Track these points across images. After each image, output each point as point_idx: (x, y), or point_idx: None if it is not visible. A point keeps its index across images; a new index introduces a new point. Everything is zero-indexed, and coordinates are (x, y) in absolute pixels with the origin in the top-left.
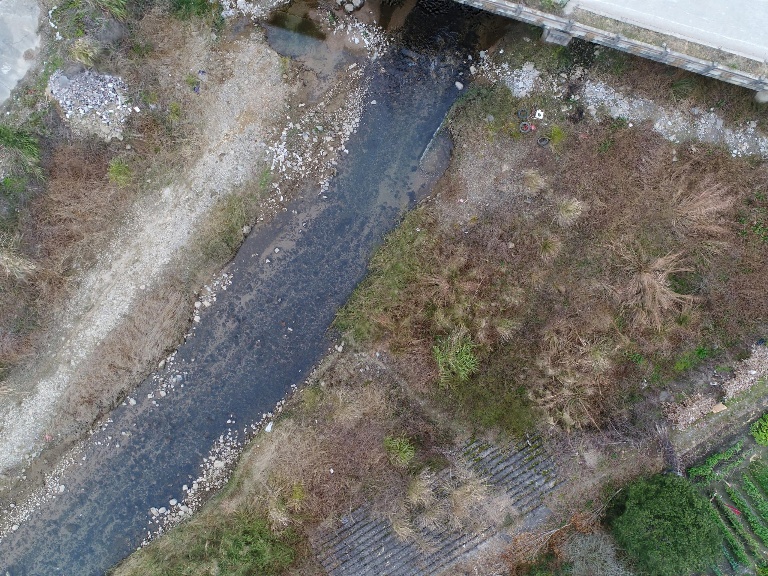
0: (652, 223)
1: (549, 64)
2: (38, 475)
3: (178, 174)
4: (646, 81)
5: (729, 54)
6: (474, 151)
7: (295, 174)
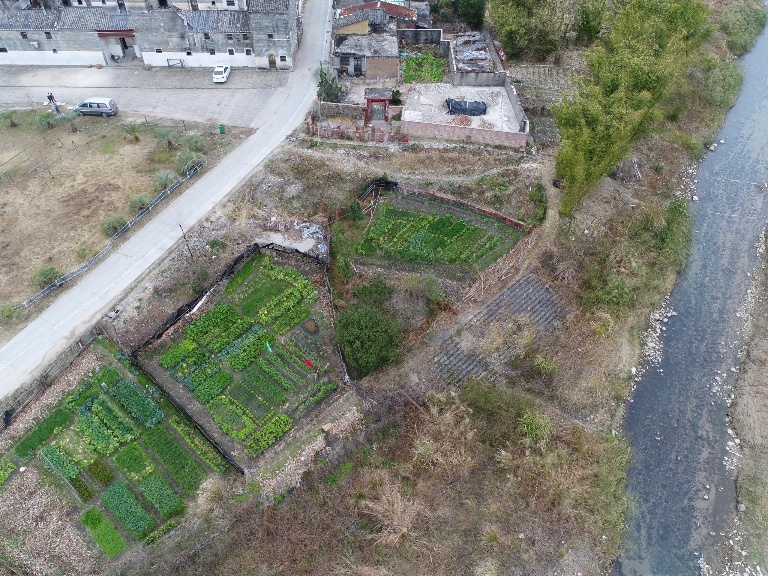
0: (411, 575)
1: None
2: (759, 319)
3: None
4: None
5: None
6: None
7: (735, 568)
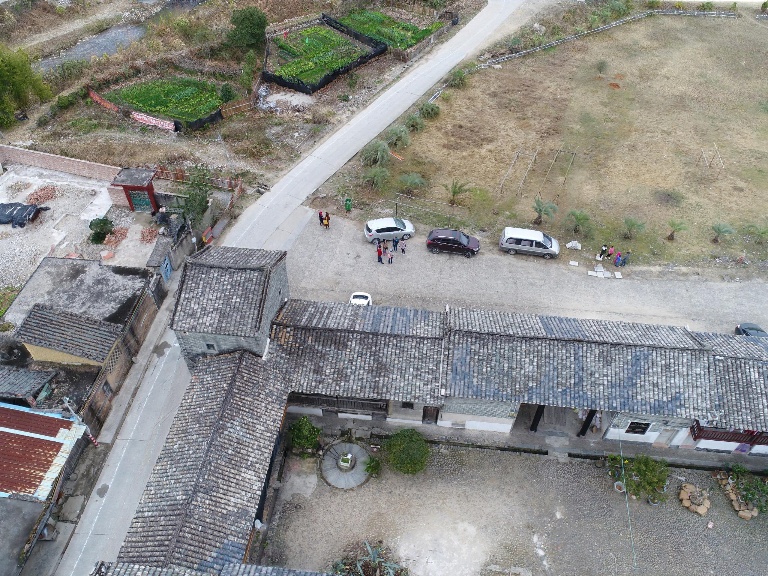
0: None
1: None
2: None
3: (84, 17)
4: None
5: None
6: (202, 9)
7: None
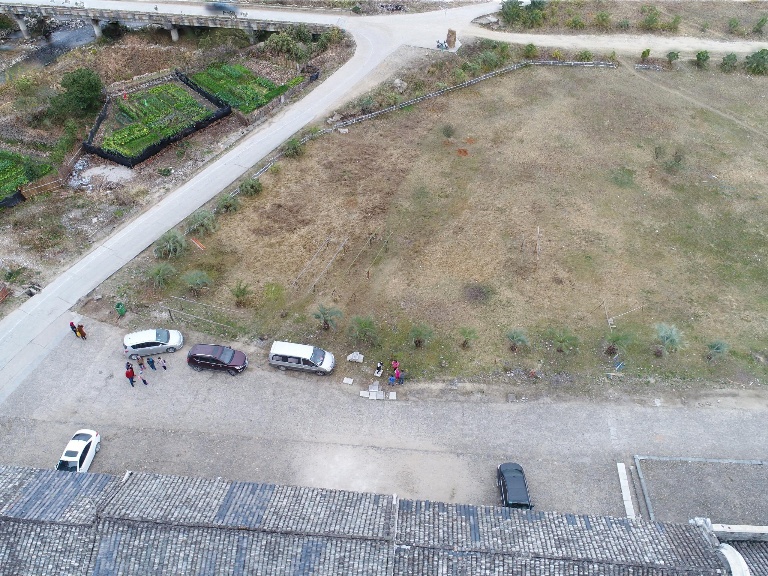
0: None
1: (100, 44)
2: None
3: None
4: (131, 39)
5: None
6: None
7: None
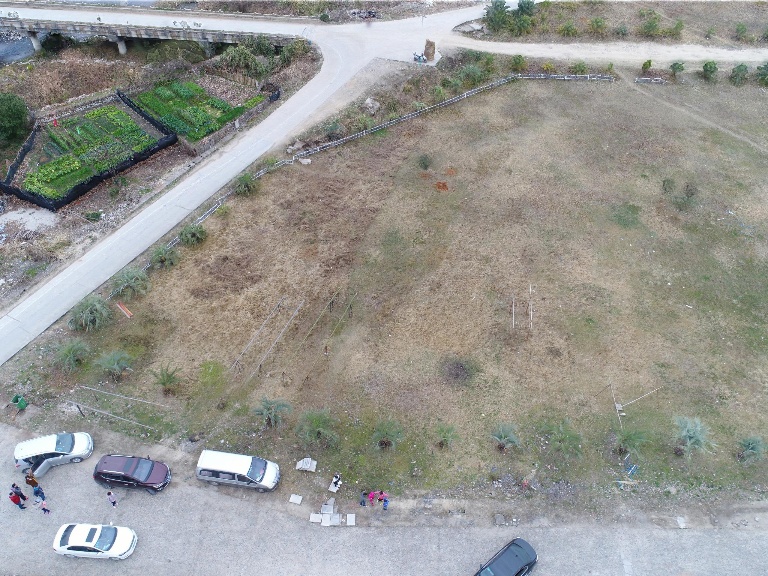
0: None
1: (38, 58)
2: None
3: None
4: (73, 52)
5: (81, 22)
6: None
7: None
